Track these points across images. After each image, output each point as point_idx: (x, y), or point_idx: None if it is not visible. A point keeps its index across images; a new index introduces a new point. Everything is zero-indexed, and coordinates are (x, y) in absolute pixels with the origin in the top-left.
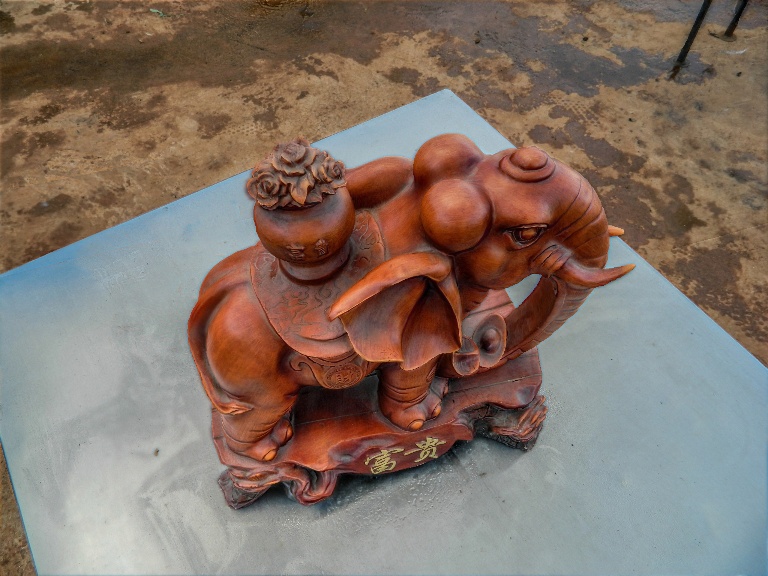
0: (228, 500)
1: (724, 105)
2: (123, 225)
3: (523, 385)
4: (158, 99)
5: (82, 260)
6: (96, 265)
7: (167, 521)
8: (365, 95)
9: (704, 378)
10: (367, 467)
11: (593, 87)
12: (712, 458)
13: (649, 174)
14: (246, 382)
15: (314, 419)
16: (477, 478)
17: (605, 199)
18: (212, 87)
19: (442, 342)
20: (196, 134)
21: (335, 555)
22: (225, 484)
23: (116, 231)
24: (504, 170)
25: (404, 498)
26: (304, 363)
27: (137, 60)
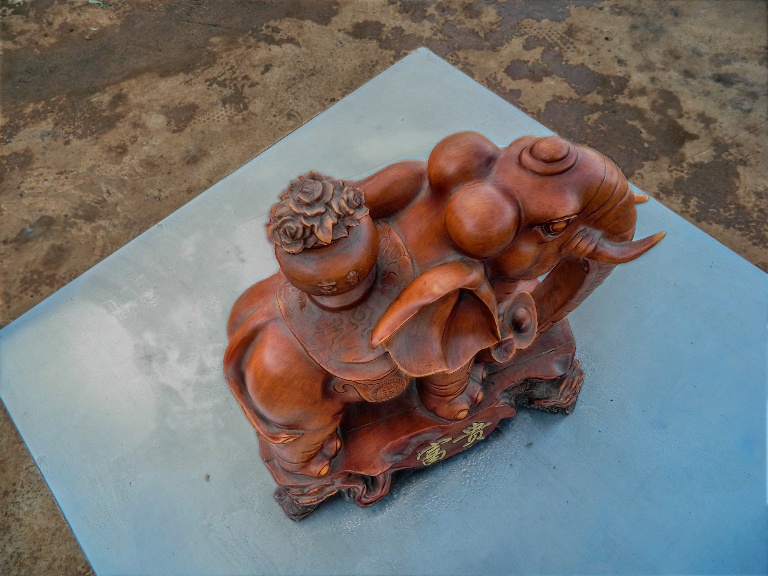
0: (288, 514)
1: (700, 6)
2: (121, 251)
3: (558, 355)
4: (119, 98)
5: (88, 295)
6: (104, 298)
7: (233, 543)
8: (331, 58)
9: (730, 311)
10: (419, 461)
11: (563, 9)
12: (749, 390)
13: (634, 94)
14: (294, 413)
15: (359, 425)
16: (525, 449)
17: (593, 128)
18: (172, 76)
19: (480, 338)
20: (166, 129)
21: (402, 548)
22: (282, 499)
23: (115, 258)
24: (526, 165)
25: (457, 481)
26: (348, 384)
27: (88, 59)
